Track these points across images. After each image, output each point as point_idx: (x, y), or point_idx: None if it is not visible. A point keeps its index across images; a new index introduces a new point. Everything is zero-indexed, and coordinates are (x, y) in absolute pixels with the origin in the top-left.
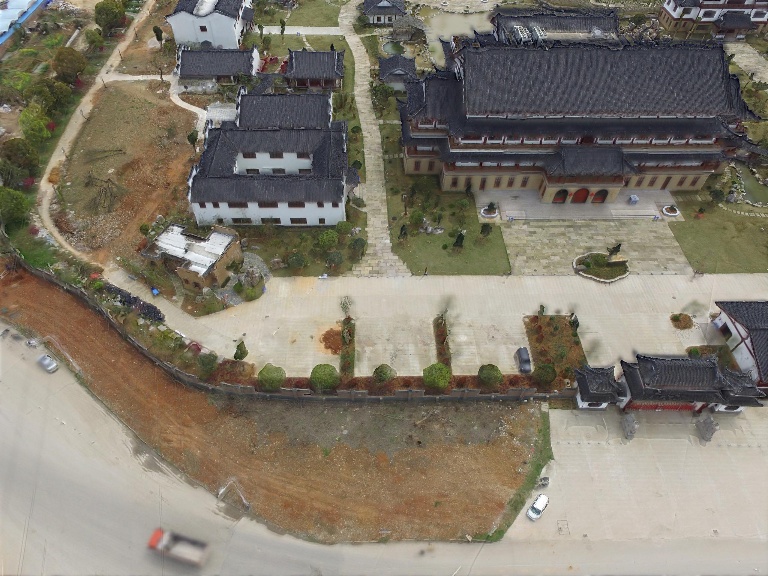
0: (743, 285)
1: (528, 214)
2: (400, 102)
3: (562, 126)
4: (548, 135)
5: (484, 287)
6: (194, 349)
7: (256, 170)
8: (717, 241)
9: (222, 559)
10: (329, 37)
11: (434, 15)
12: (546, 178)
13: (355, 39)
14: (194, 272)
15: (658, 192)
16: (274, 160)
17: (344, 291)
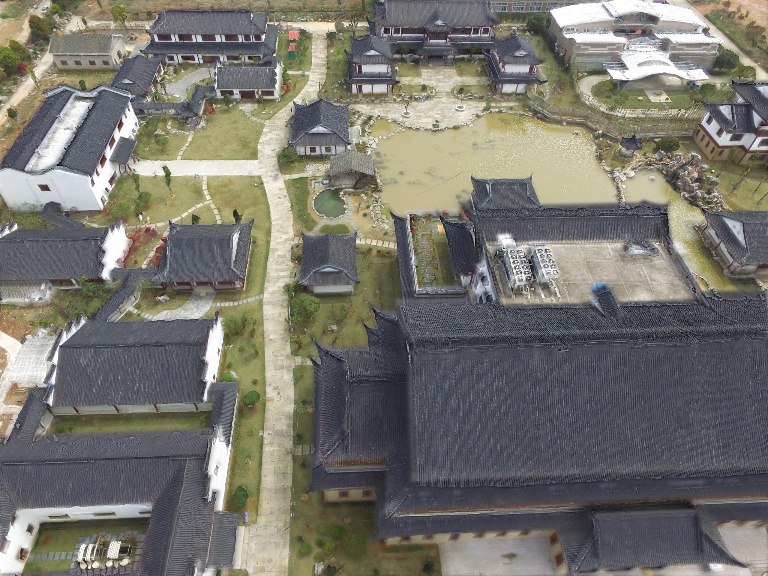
0: None
1: None
2: (317, 366)
3: None
4: (569, 501)
5: None
6: None
7: (62, 515)
8: None
9: None
10: (240, 180)
11: (391, 134)
12: (563, 545)
13: (277, 183)
14: None
15: (748, 532)
16: (88, 508)
17: None
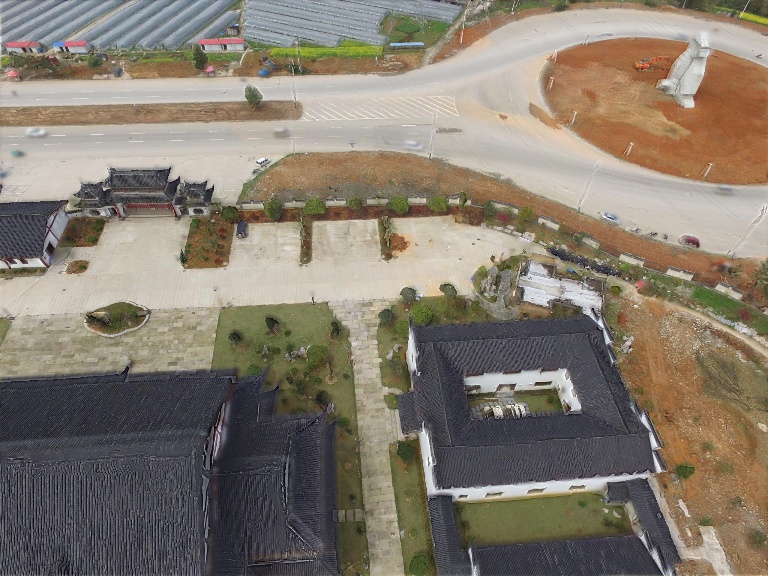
0: None
1: None
2: (333, 573)
3: None
4: None
5: (255, 293)
6: (502, 213)
7: None
8: None
9: (436, 145)
10: None
11: None
12: None
13: None
14: (536, 254)
15: None
16: None
17: (396, 284)
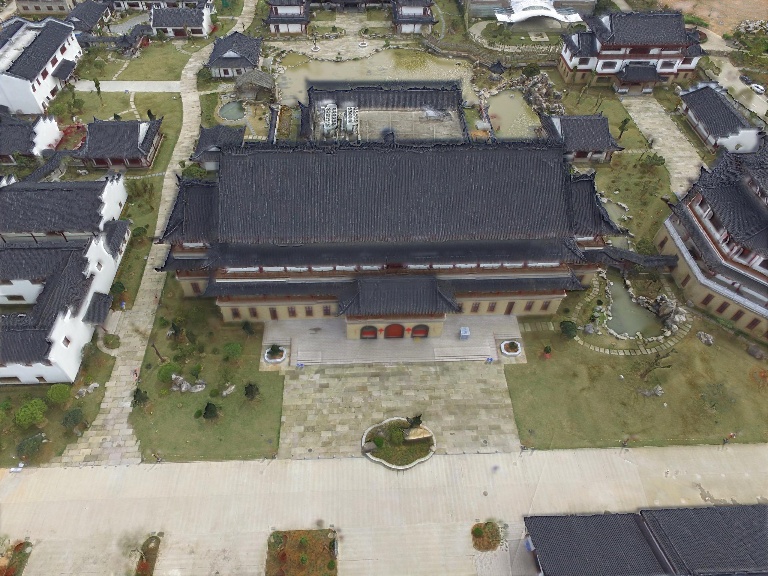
0: (582, 469)
1: (325, 357)
2: None
3: (355, 250)
4: (335, 263)
5: (232, 481)
6: None
7: None
8: (561, 396)
9: None
10: (163, 95)
11: (299, 64)
12: None
13: (193, 97)
14: None
15: (501, 318)
16: (1, 287)
17: (37, 493)
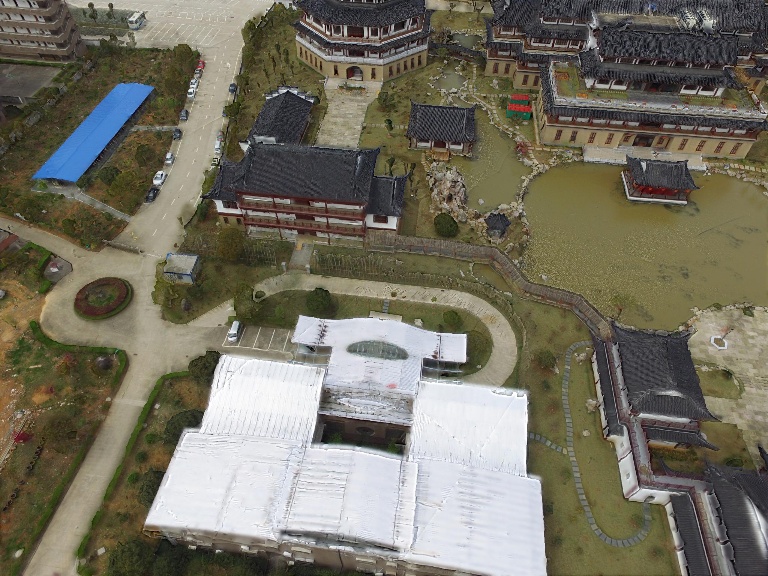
0: None
1: None
2: None
3: None
4: None
5: None
6: None
7: None
8: None
9: None
10: None
11: None
12: None
13: None
14: None
15: None
16: None
17: None
